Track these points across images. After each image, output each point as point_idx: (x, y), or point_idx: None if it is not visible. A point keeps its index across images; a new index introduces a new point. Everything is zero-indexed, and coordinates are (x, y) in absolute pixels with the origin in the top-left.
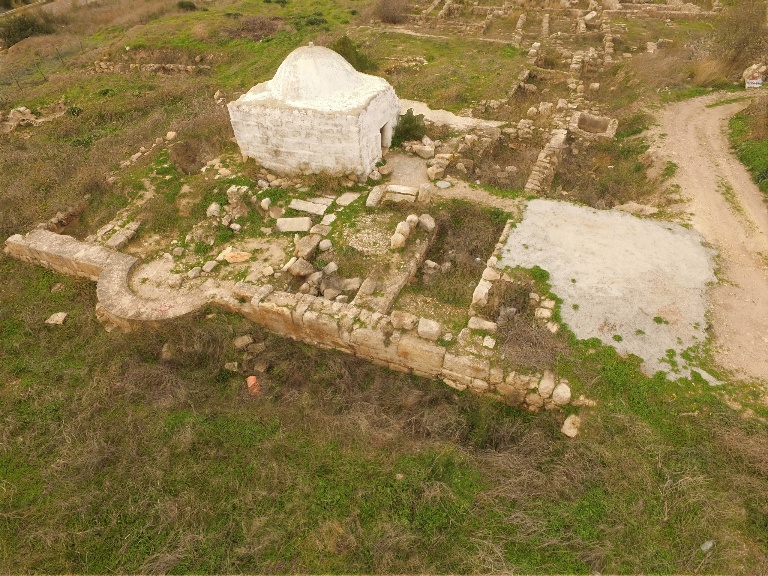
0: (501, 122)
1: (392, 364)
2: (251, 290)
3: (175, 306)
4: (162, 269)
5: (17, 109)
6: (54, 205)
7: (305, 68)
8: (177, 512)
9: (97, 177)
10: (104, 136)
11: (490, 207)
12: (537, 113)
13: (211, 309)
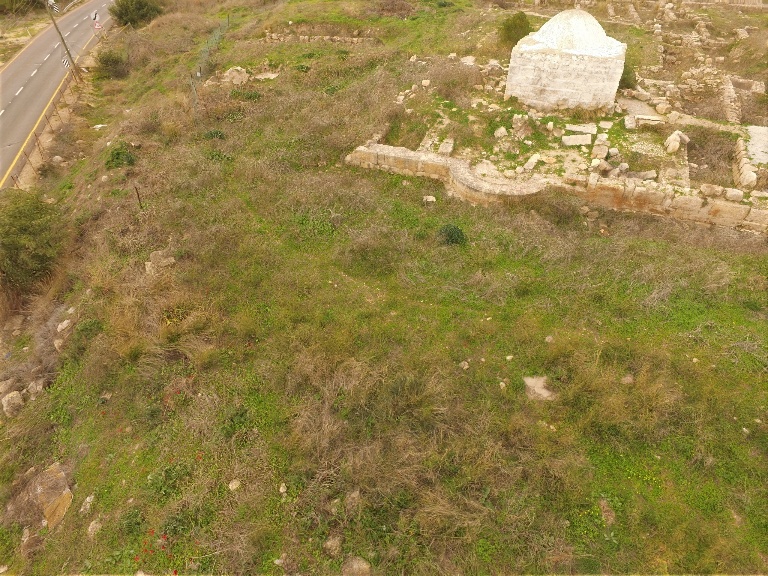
0: (669, 81)
1: (698, 222)
2: (580, 177)
3: (525, 188)
4: (489, 169)
5: (235, 68)
6: (369, 129)
7: (578, 25)
8: (654, 273)
9: (398, 109)
10: (342, 87)
11: (719, 130)
12: (691, 76)
13: (551, 190)
